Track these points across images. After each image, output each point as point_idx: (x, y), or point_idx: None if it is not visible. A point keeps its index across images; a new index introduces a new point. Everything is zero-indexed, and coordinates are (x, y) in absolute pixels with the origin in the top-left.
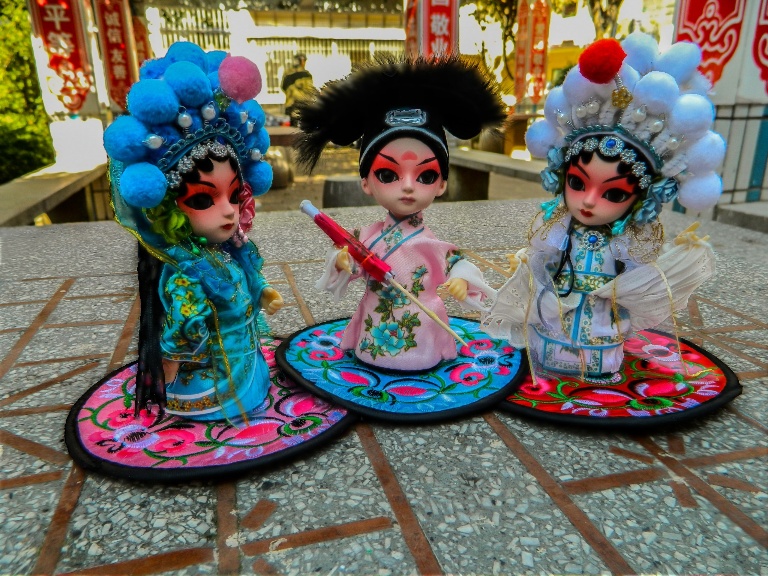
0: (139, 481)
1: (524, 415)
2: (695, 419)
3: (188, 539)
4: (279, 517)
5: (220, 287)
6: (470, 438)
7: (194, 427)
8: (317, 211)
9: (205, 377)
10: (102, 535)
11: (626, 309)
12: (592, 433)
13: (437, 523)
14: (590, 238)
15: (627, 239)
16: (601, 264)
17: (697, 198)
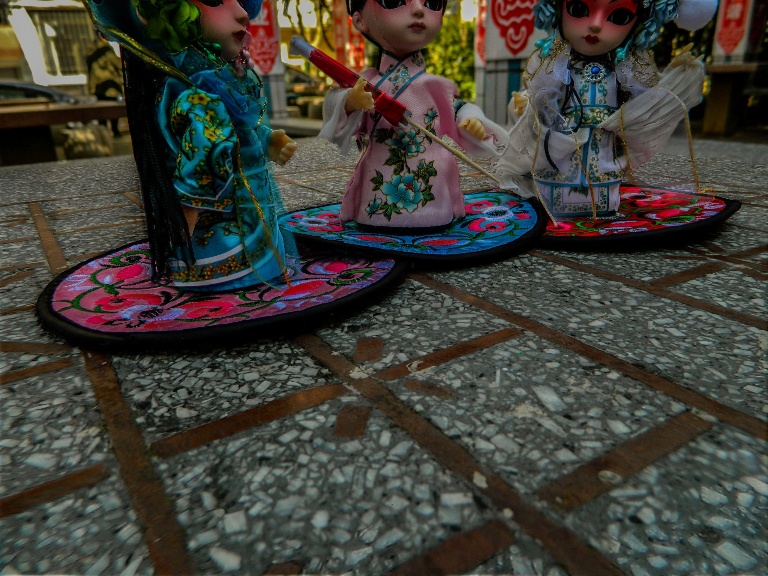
0: (189, 349)
1: (569, 244)
2: (709, 232)
3: (302, 382)
4: (394, 347)
5: (249, 104)
6: (531, 268)
7: (220, 297)
8: (312, 47)
9: (228, 232)
10: (183, 399)
11: (623, 145)
12: (637, 250)
13: (565, 324)
14: (593, 69)
15: (631, 64)
16: (605, 95)
17: (699, 11)
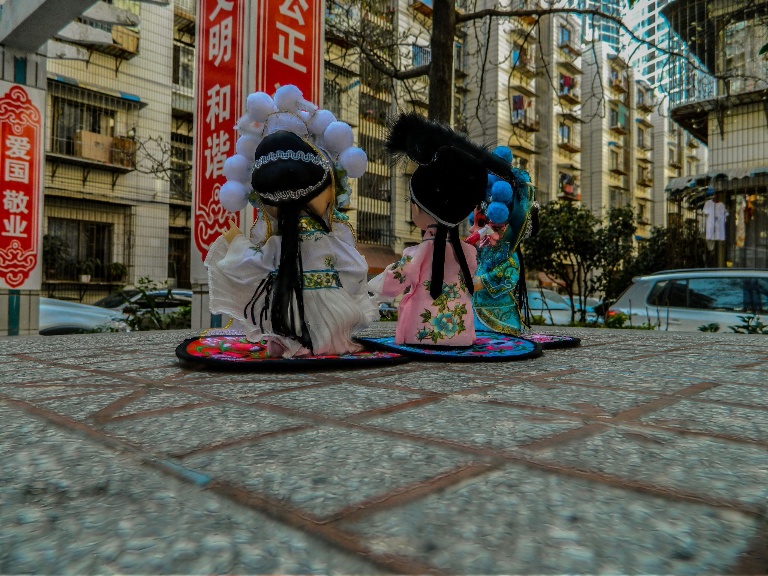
0: None
1: None
2: None
3: None
4: None
5: None
6: None
7: None
8: None
9: None
10: None
11: None
12: None
13: None
14: None
15: None
16: None
17: None
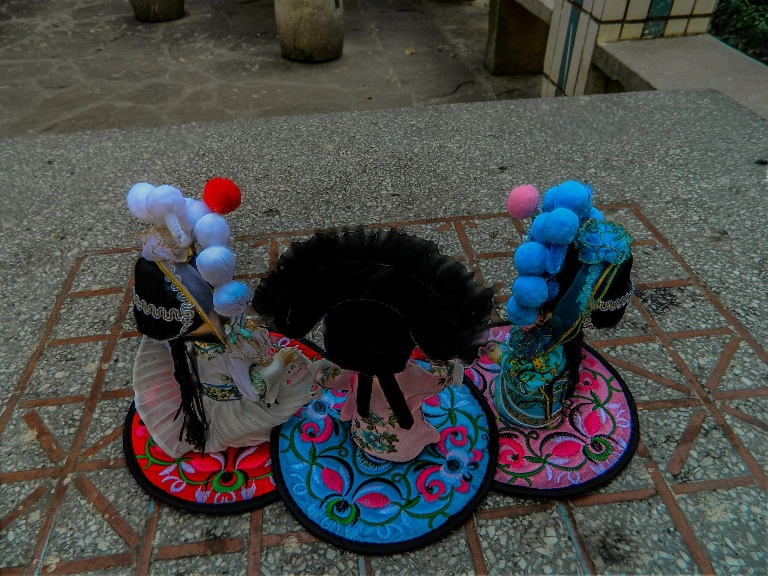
0: None
1: None
2: None
3: None
4: None
5: None
6: None
7: None
8: None
9: None
10: None
11: None
12: None
13: None
14: None
15: None
16: None
17: None
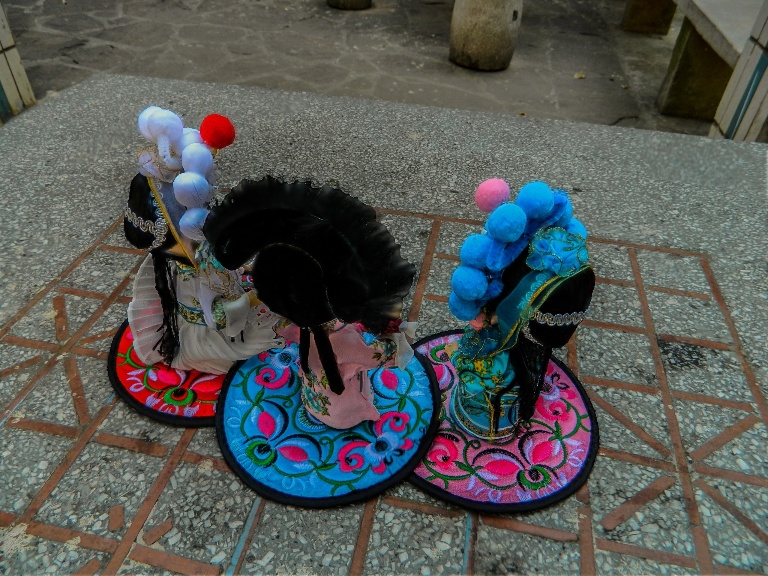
0: None
1: None
2: None
3: None
4: None
5: None
6: None
7: None
8: None
9: None
10: None
11: None
12: None
13: None
14: None
15: None
16: None
17: None
